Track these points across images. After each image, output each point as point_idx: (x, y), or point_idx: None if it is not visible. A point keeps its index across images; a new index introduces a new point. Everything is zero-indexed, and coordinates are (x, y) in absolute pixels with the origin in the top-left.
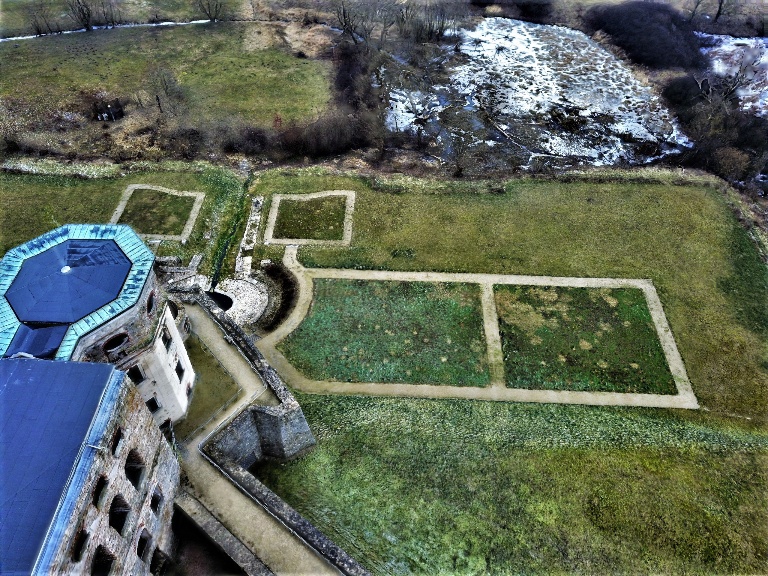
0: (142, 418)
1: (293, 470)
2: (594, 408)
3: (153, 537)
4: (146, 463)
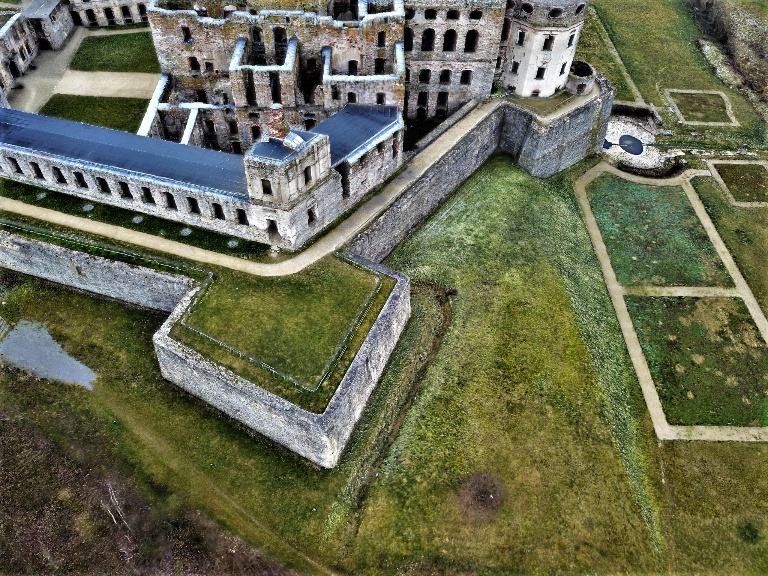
0: (494, 32)
1: (510, 167)
2: (625, 351)
3: (451, 85)
4: (478, 52)
